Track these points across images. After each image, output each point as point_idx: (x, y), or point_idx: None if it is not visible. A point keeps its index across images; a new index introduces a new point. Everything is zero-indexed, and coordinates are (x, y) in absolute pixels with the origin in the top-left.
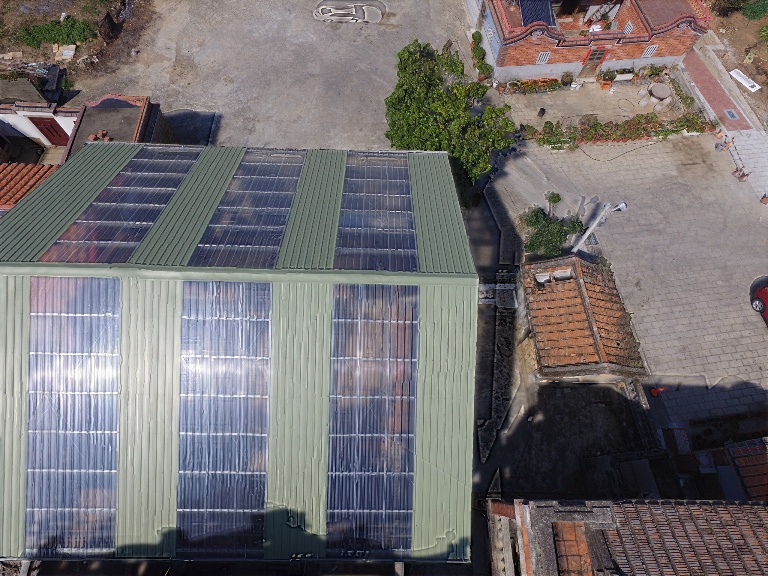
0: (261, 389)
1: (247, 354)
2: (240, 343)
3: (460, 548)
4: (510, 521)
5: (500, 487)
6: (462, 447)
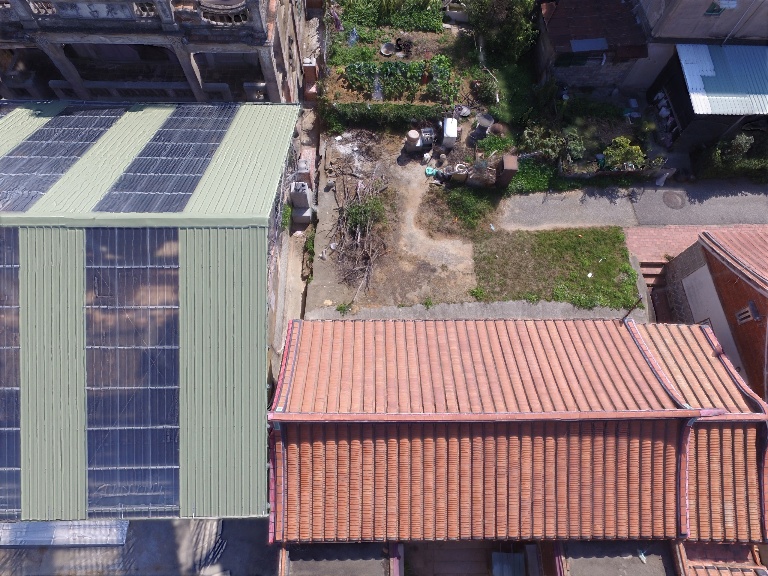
0: (6, 160)
1: (1, 176)
2: (2, 181)
3: None
4: None
5: None
6: None
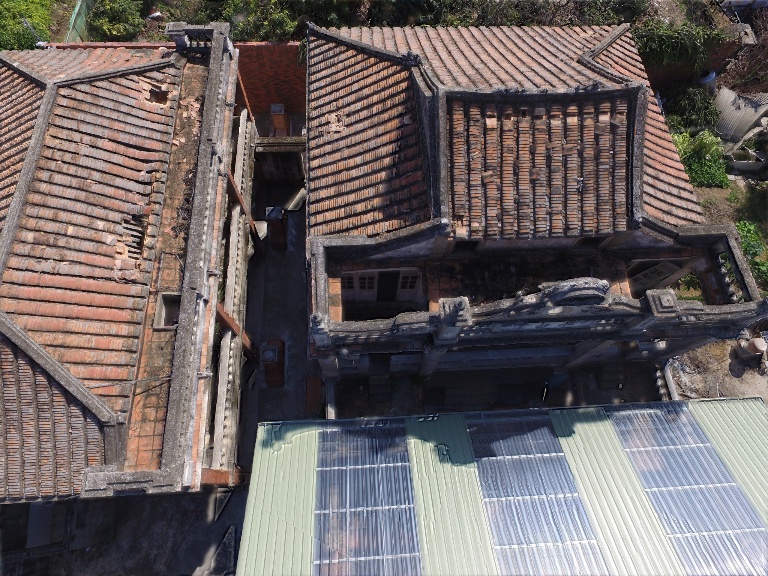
0: None
1: None
2: None
3: (268, 436)
4: (210, 465)
5: (217, 499)
6: (253, 551)
